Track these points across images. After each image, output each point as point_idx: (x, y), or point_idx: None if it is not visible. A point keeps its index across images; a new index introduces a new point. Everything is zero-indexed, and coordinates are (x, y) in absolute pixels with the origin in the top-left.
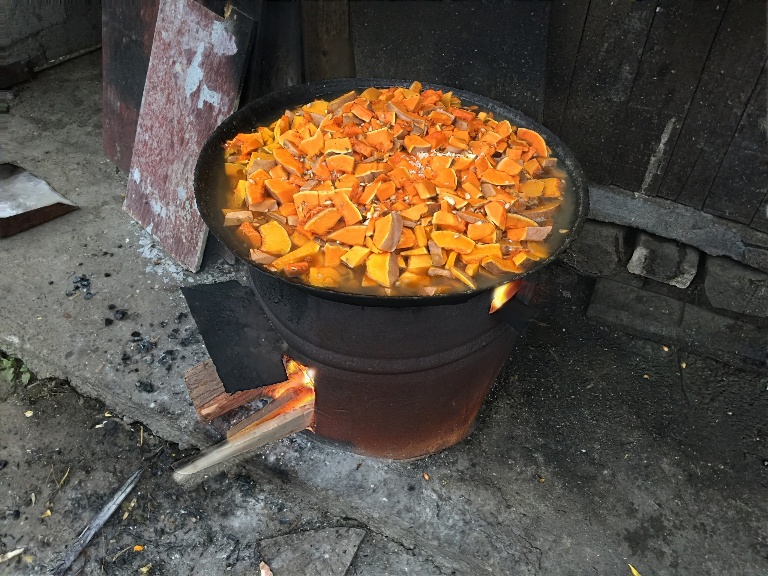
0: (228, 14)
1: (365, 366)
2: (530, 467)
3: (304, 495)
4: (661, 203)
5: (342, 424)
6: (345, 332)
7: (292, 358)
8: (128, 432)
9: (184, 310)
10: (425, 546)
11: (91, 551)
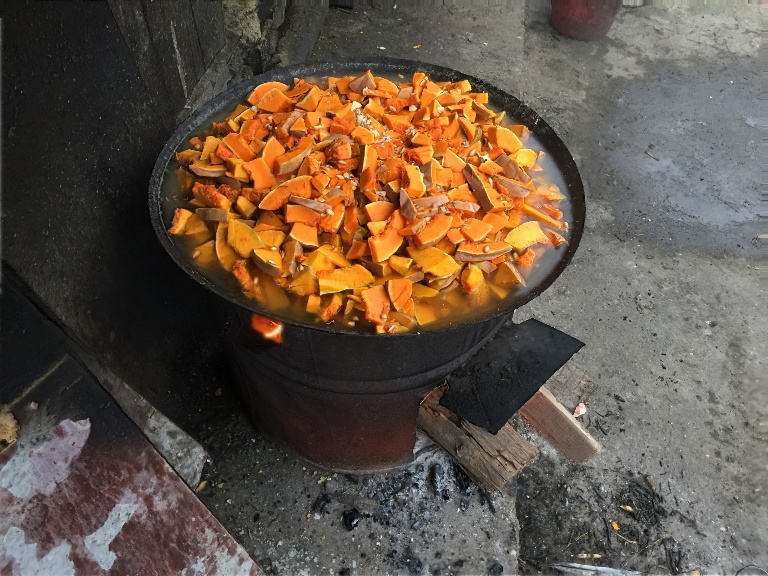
0: (13, 427)
1: None
2: None
3: None
4: (197, 94)
5: None
6: None
7: None
8: None
9: None
10: None
11: (641, 569)
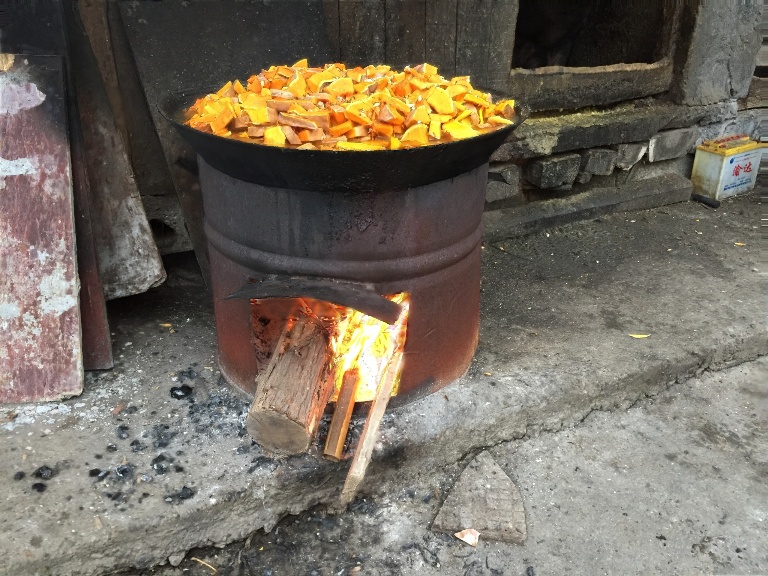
0: (10, 63)
1: (452, 254)
2: (521, 333)
3: (421, 464)
4: None
5: (427, 354)
6: (439, 219)
7: (383, 294)
8: (184, 575)
9: (115, 426)
10: (536, 418)
11: None
